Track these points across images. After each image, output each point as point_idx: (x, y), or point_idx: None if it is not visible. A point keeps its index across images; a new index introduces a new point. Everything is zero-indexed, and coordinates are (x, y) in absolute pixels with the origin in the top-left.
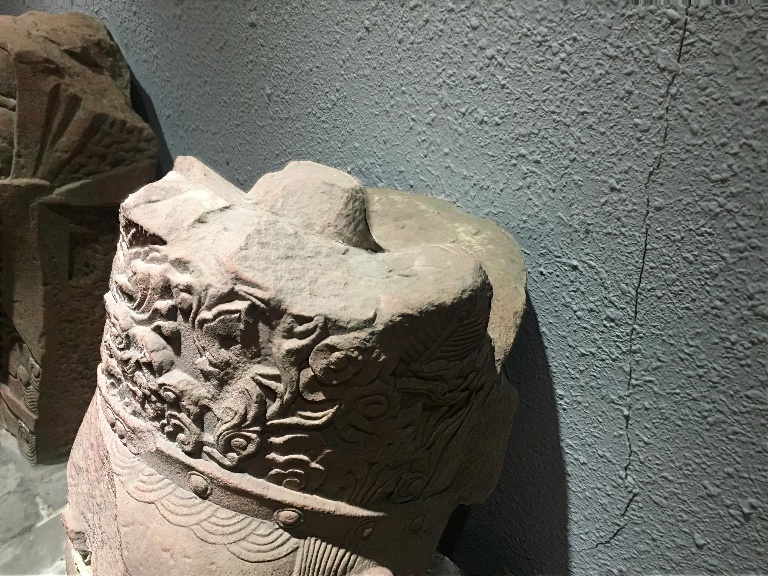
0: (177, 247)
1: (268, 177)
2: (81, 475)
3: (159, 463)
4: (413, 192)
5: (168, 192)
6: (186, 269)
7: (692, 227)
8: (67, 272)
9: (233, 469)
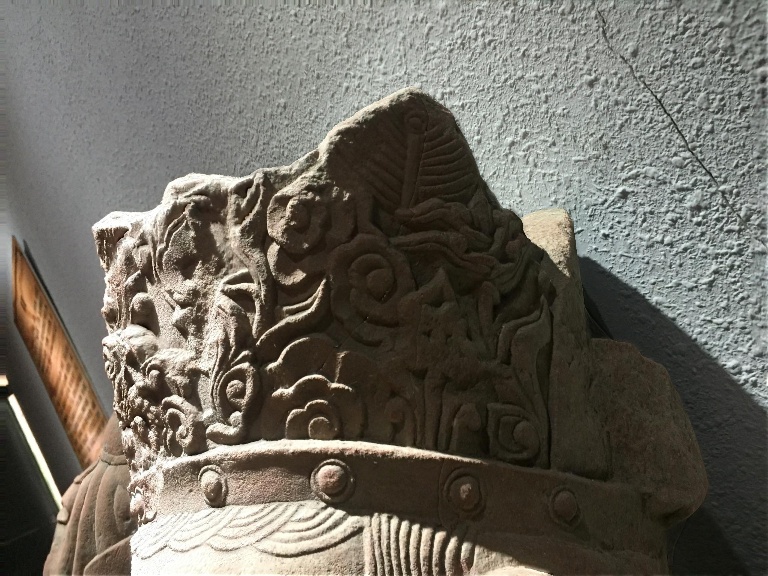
0: None
1: None
2: None
3: (172, 498)
4: None
5: None
6: None
7: (672, 33)
8: None
9: (244, 441)
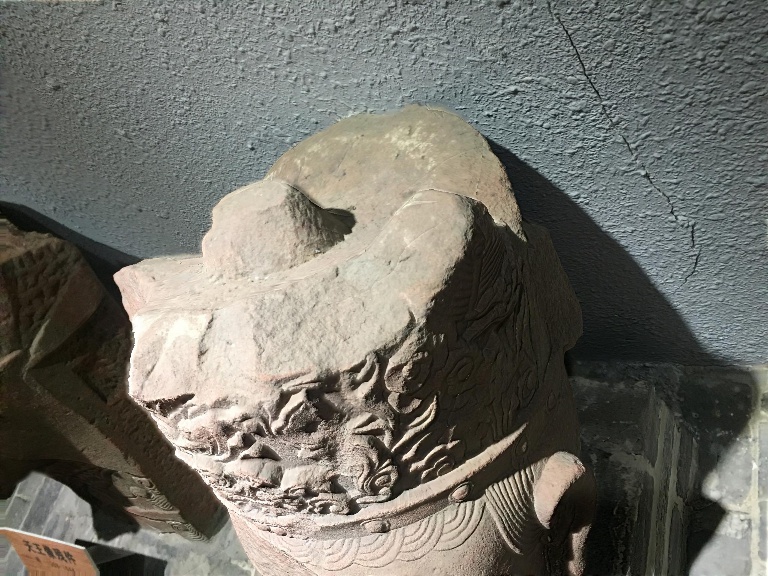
0: (206, 391)
1: (209, 243)
2: (272, 568)
3: (331, 533)
4: (322, 127)
5: (155, 350)
6: (230, 403)
7: None
8: (99, 399)
9: (392, 497)
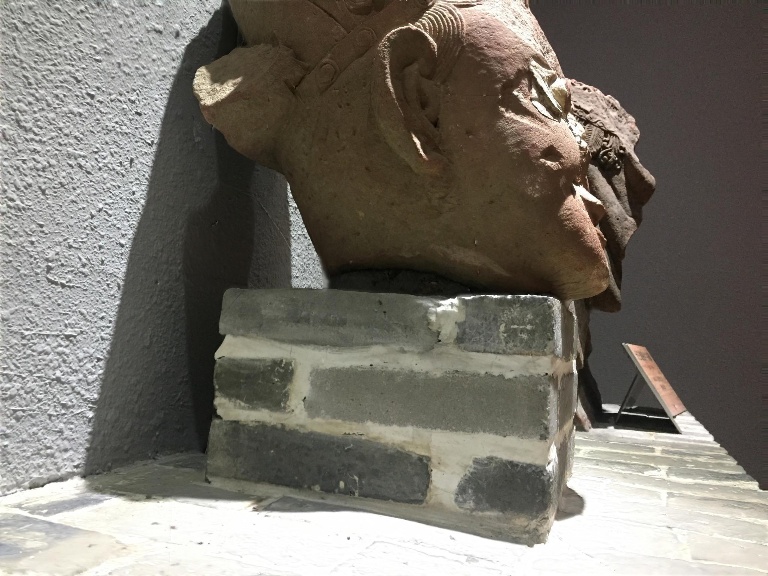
0: None
1: None
2: None
3: None
4: None
5: None
6: None
7: None
8: None
9: None
